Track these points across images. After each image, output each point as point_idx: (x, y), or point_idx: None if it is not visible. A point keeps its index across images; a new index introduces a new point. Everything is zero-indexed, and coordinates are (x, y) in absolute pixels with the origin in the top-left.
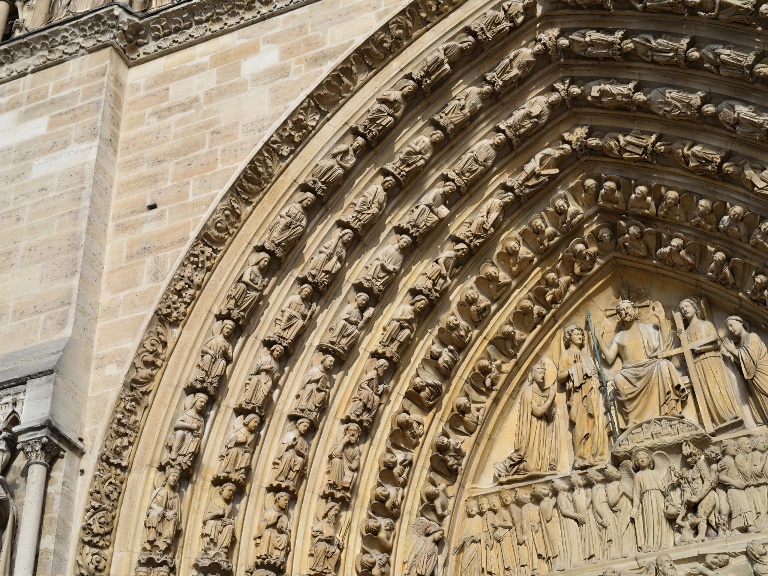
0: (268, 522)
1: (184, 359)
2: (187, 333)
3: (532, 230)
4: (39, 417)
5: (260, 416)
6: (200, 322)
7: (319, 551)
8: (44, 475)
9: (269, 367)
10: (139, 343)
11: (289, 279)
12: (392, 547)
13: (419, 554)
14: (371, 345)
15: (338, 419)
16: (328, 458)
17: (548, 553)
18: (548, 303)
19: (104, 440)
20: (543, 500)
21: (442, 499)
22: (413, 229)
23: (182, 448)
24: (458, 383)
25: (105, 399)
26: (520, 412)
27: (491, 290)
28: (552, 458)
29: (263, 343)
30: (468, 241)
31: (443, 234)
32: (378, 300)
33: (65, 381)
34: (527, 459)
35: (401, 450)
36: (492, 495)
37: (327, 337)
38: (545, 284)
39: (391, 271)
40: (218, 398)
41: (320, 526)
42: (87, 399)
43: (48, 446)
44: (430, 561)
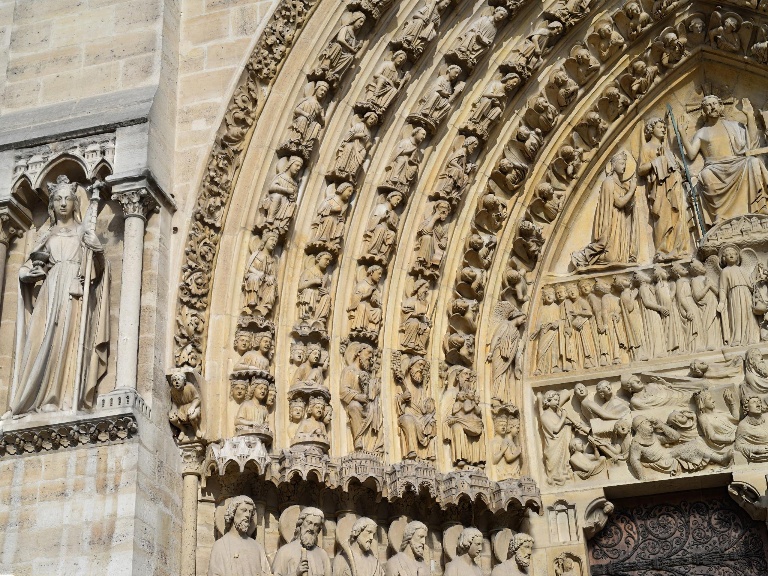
0: (363, 295)
1: (276, 119)
2: (277, 92)
3: (626, 14)
4: (135, 167)
5: (353, 185)
6: (292, 81)
7: (412, 327)
8: (142, 229)
9: (363, 135)
10: (230, 98)
11: (381, 44)
12: (476, 329)
13: (503, 337)
14: (459, 121)
15: (426, 195)
16: (416, 235)
17: (631, 343)
18: (633, 93)
19: (197, 198)
20: (624, 291)
21: (523, 284)
22: (510, 1)
23: (279, 212)
24: (541, 168)
25: (195, 155)
26: (601, 202)
27: (580, 74)
28: (633, 250)
29: (354, 110)
30: (564, 19)
31: (536, 10)
32: (469, 74)
33: (157, 132)
34: (609, 249)
35: (484, 232)
36: (570, 284)
37: (418, 109)
38: (632, 72)
39: (486, 44)
40: (310, 163)
41: (410, 303)
42: (174, 154)
43: (146, 199)
44: (513, 345)
